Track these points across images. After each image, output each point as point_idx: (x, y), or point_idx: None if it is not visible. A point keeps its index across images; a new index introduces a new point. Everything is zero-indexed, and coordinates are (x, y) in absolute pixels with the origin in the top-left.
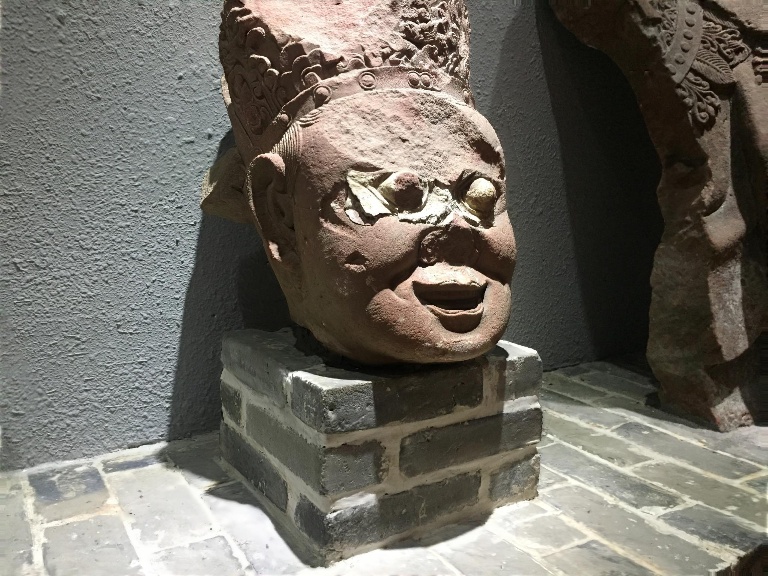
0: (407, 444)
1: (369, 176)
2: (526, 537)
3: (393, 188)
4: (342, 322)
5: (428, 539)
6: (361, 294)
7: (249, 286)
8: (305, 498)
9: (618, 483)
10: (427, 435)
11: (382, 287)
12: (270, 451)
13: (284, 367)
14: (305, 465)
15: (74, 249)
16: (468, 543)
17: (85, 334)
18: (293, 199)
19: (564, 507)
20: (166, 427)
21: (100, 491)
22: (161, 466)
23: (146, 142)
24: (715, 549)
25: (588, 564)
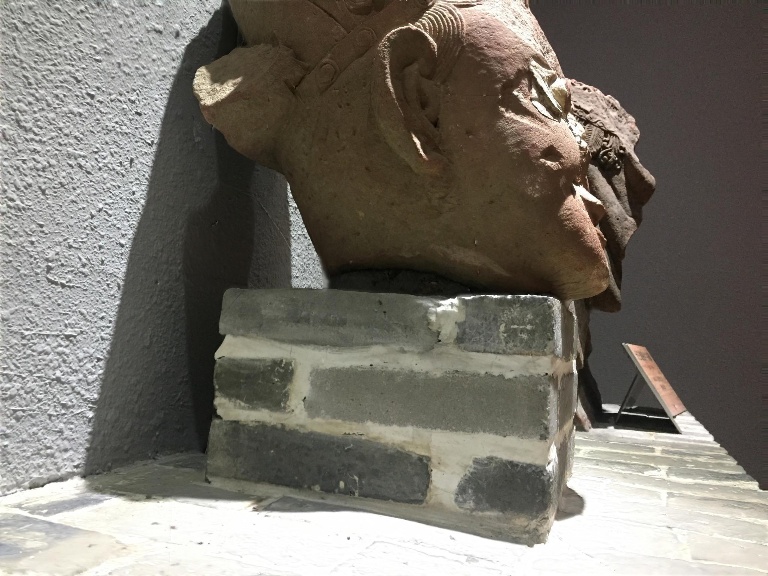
0: (560, 389)
1: (546, 72)
2: (628, 497)
3: (566, 90)
4: (519, 233)
5: (568, 510)
6: (553, 196)
7: (194, 250)
8: (491, 460)
9: (599, 462)
10: (564, 382)
11: (569, 192)
12: (389, 421)
13: (423, 298)
14: (500, 410)
15: (7, 122)
16: (603, 507)
17: (2, 271)
18: (444, 87)
19: (605, 477)
20: (84, 452)
21: (83, 533)
22: (124, 500)
23: (114, 5)
24: (738, 485)
25: (703, 504)
